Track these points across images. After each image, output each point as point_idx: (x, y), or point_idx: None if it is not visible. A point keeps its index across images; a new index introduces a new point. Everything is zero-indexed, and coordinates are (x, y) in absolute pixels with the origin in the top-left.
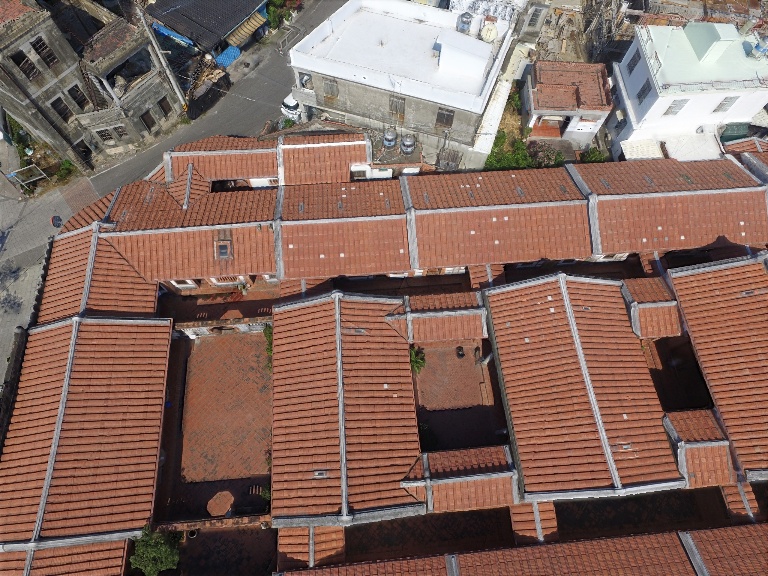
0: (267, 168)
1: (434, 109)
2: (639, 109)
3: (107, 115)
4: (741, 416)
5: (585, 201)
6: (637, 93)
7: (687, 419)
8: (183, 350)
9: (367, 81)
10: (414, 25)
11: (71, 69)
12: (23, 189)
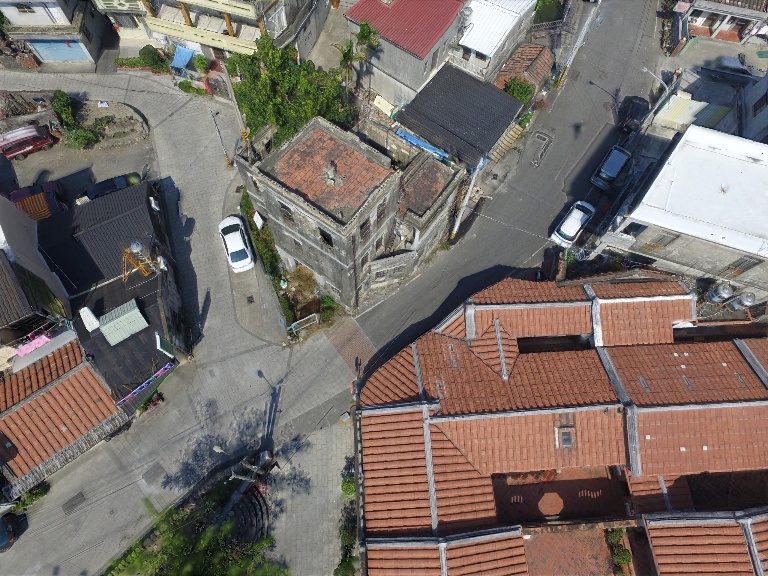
0: (579, 324)
1: None
2: None
3: (400, 260)
4: None
5: None
6: None
7: None
8: None
9: (725, 241)
10: (750, 165)
11: (387, 220)
12: (291, 335)
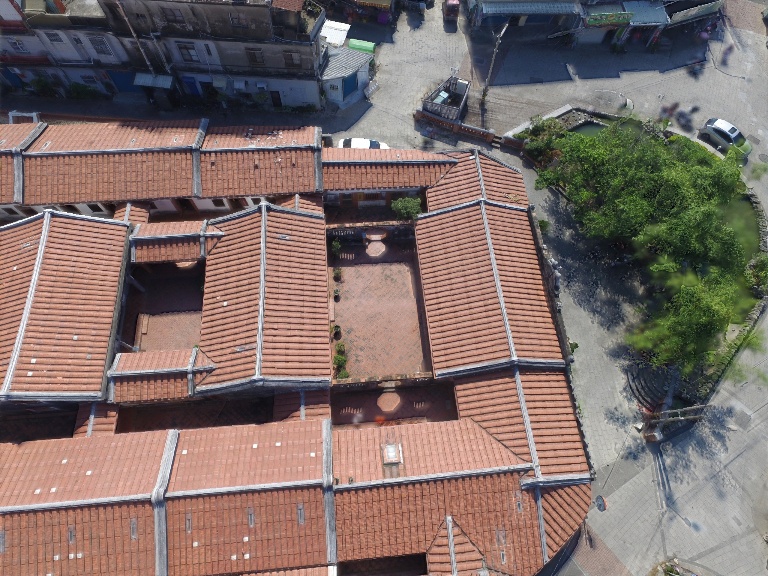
0: None
1: None
2: None
3: None
4: None
5: None
6: None
7: None
8: (429, 366)
9: None
10: None
11: None
12: (676, 571)
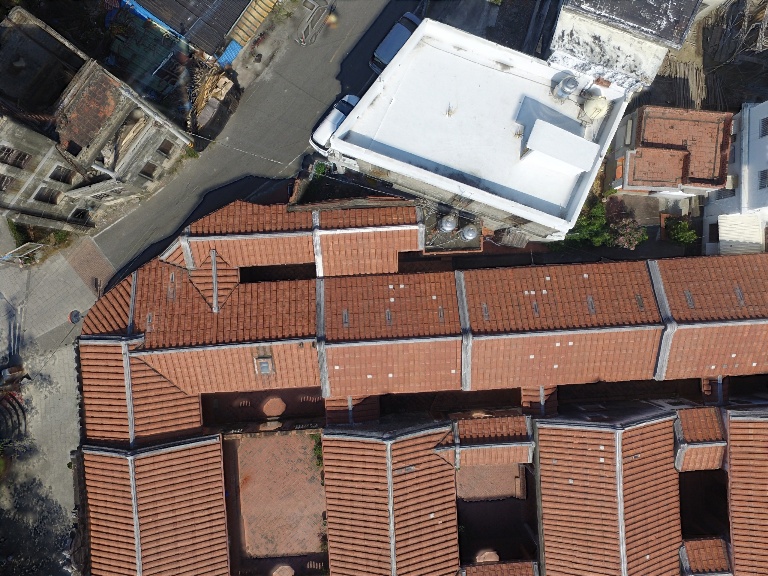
0: (302, 253)
1: (508, 213)
2: (757, 193)
3: (101, 187)
4: (752, 559)
5: (662, 327)
6: (761, 170)
7: (702, 549)
8: (232, 442)
9: (429, 180)
10: (494, 75)
11: (47, 155)
12: (22, 259)
